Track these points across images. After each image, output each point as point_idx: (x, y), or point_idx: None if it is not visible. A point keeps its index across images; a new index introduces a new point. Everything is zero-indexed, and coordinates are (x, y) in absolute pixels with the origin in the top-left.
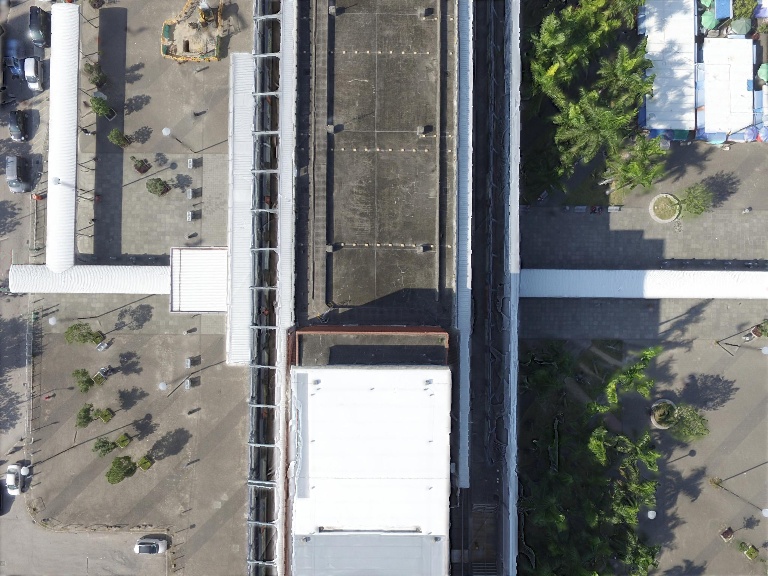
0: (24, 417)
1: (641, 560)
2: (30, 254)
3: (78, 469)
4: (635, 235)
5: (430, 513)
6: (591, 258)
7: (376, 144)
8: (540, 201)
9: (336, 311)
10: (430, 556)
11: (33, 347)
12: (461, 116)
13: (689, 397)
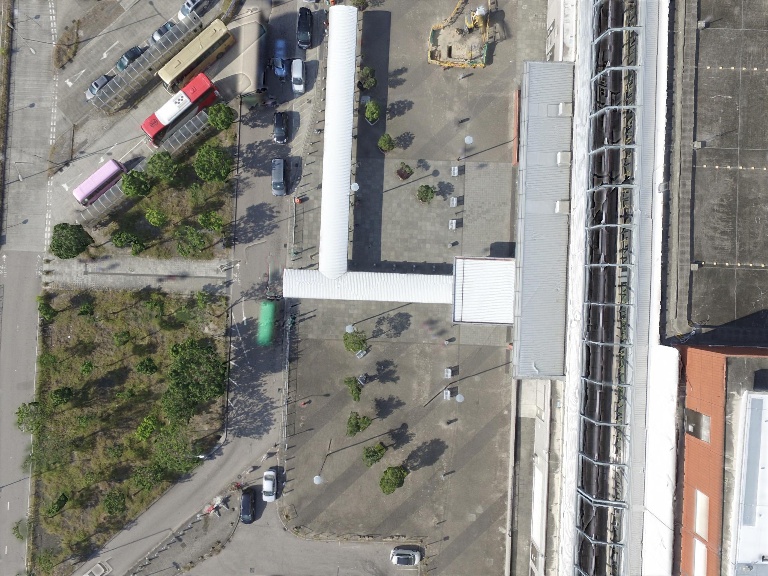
0: (278, 423)
1: None
2: (291, 258)
3: (332, 477)
4: None
5: None
6: None
7: (738, 162)
8: None
9: (698, 331)
10: None
11: (289, 352)
12: None
13: None
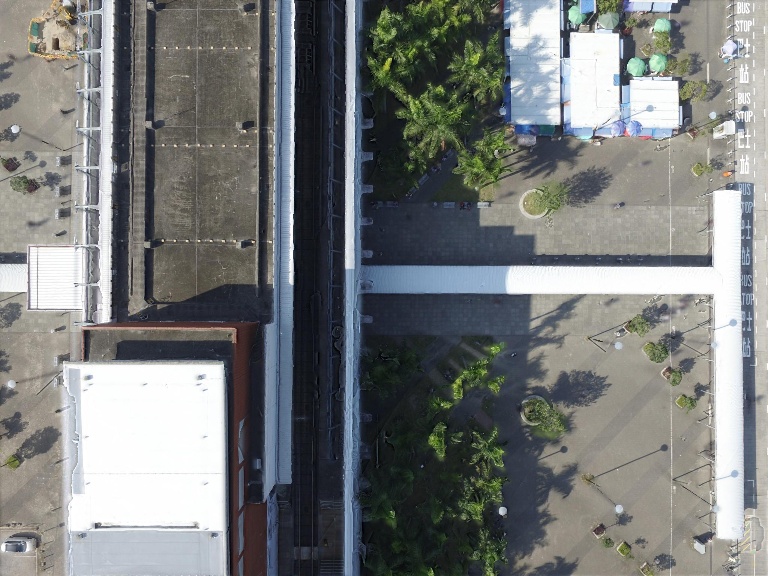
0: None
1: (488, 556)
2: None
3: None
4: (506, 231)
5: (207, 509)
6: (461, 254)
7: (197, 140)
8: (408, 197)
9: (155, 307)
10: (208, 552)
11: None
12: (283, 111)
13: (561, 393)
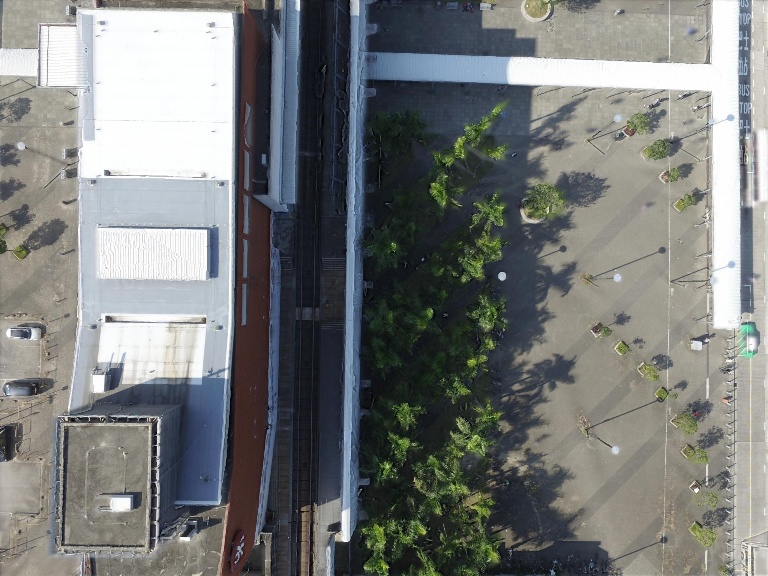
0: None
1: (487, 315)
2: None
3: None
4: (507, 34)
5: (213, 157)
6: None
7: None
8: None
9: None
10: (214, 201)
11: None
12: None
13: (560, 194)
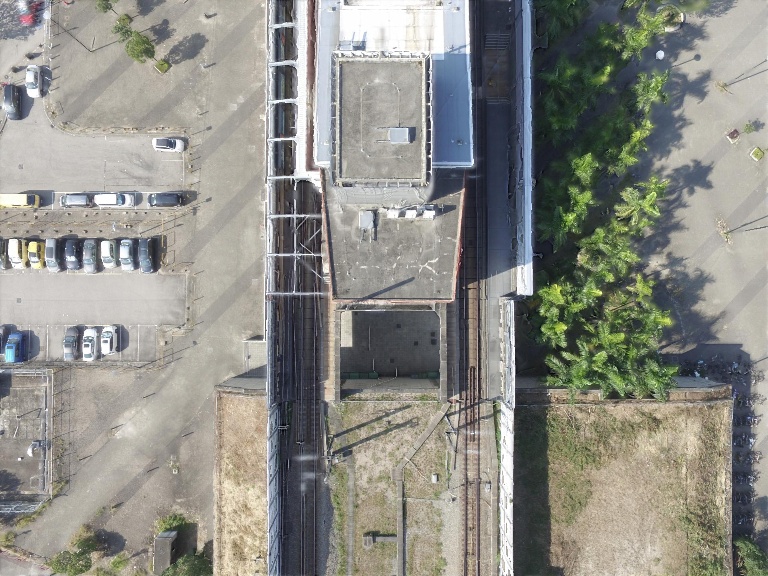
0: (43, 24)
1: (650, 87)
2: None
3: (96, 73)
4: None
5: None
6: None
7: None
8: None
9: None
10: None
11: None
12: None
13: (693, 4)
